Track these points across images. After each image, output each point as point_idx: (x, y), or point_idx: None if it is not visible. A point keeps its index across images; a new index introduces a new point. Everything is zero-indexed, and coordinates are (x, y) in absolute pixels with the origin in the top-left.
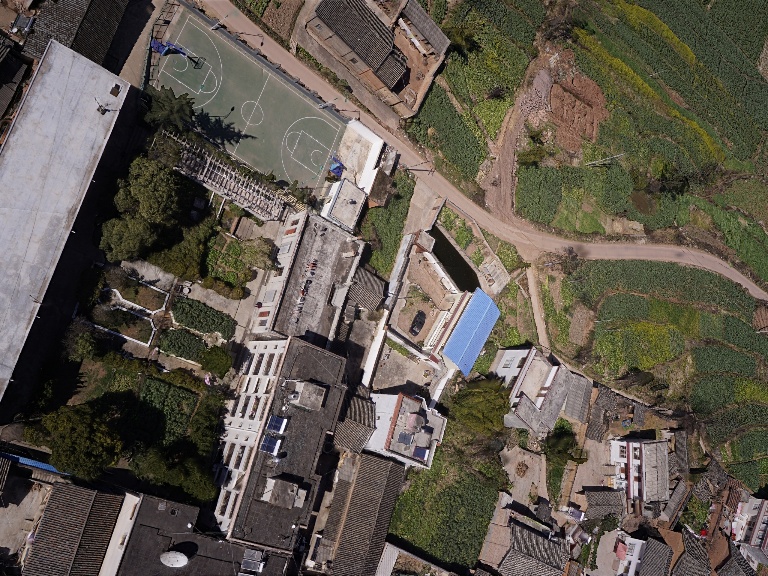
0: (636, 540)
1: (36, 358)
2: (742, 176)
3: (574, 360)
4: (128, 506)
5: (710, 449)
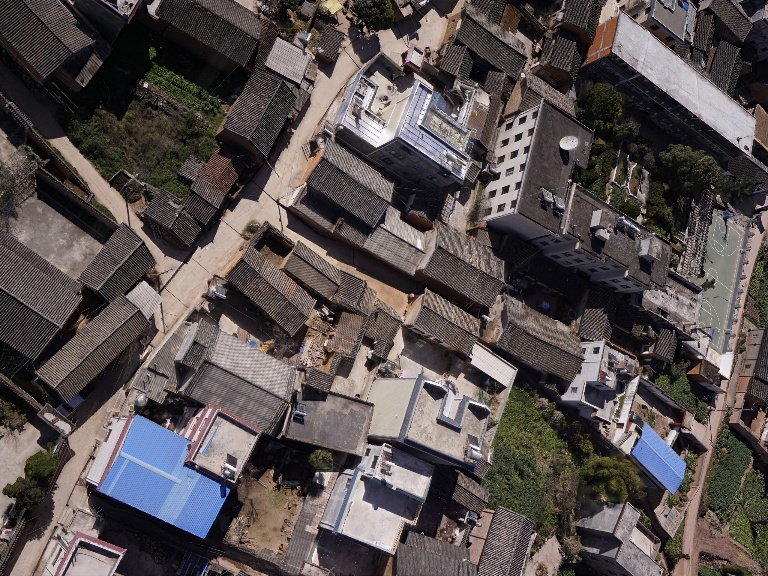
0: None
1: None
2: None
3: None
4: None
5: None
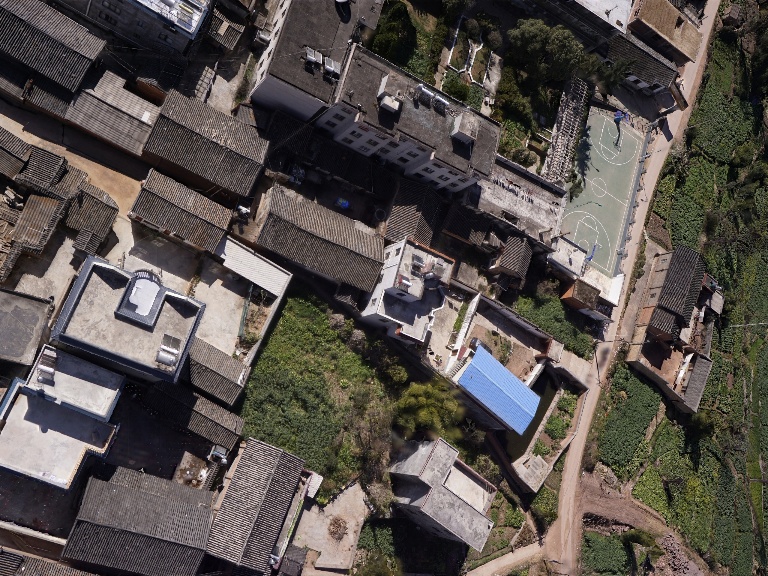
0: None
1: None
2: None
3: None
4: None
5: None
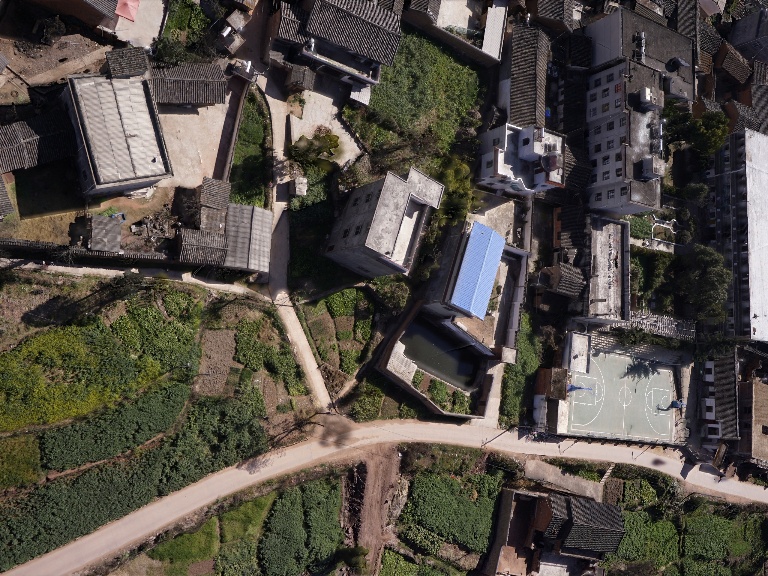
0: None
1: None
2: None
3: None
4: None
5: None
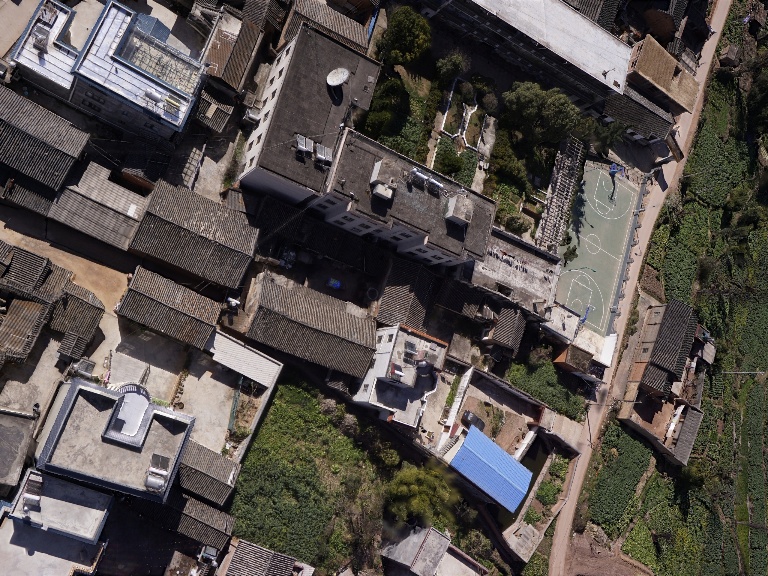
0: None
1: None
2: None
3: None
4: None
5: None
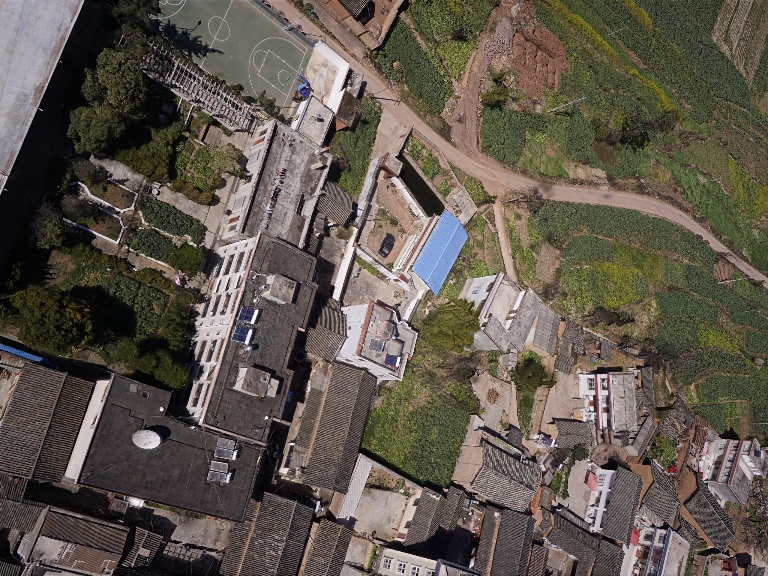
0: (606, 471)
1: (3, 246)
2: (700, 136)
3: (541, 295)
4: (99, 391)
5: (676, 390)
